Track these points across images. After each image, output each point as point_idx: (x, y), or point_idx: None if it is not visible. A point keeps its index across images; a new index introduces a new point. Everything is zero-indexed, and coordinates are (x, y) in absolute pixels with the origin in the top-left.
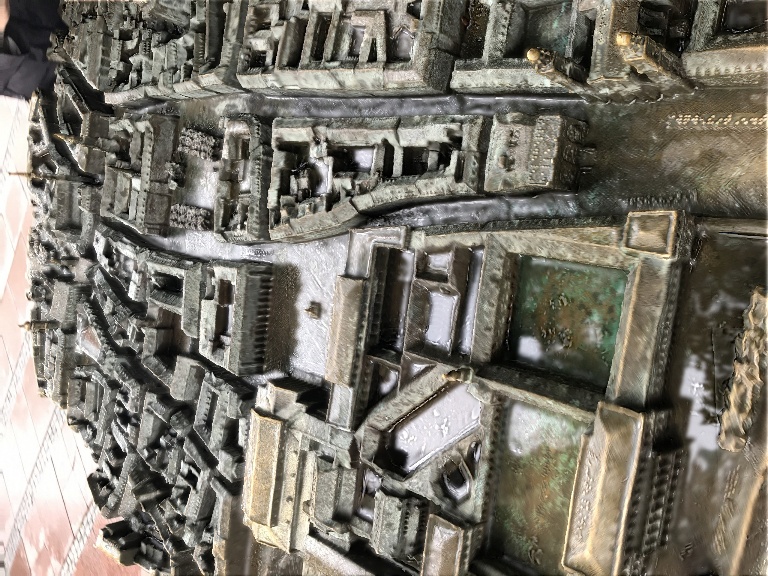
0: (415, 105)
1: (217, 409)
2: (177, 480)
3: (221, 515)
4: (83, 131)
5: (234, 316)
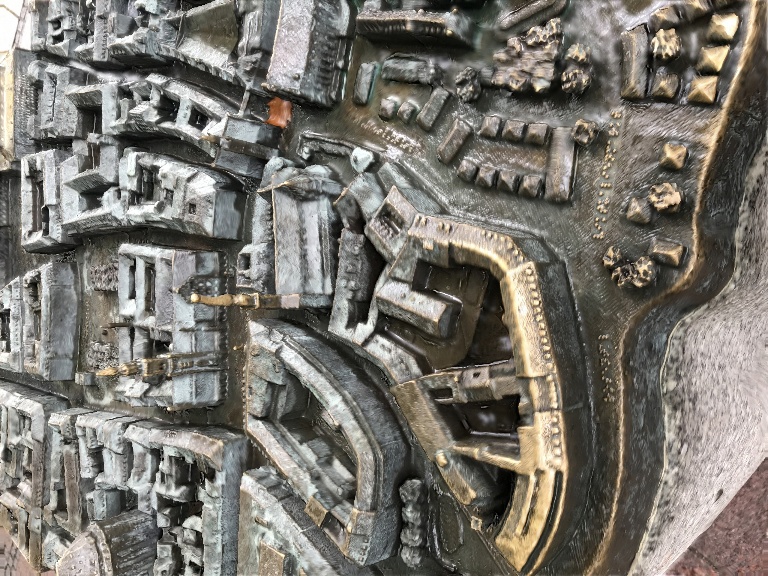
0: (2, 374)
1: (41, 112)
2: (61, 8)
3: (31, 28)
4: (246, 397)
5: (22, 205)
